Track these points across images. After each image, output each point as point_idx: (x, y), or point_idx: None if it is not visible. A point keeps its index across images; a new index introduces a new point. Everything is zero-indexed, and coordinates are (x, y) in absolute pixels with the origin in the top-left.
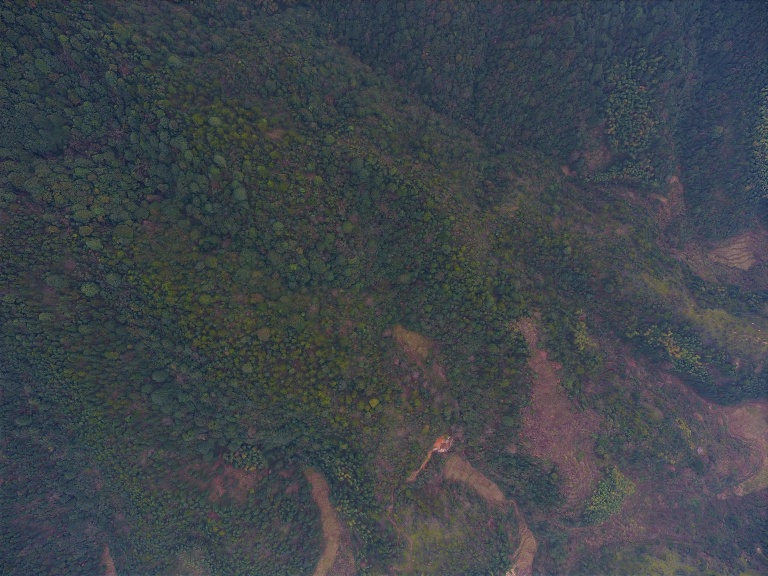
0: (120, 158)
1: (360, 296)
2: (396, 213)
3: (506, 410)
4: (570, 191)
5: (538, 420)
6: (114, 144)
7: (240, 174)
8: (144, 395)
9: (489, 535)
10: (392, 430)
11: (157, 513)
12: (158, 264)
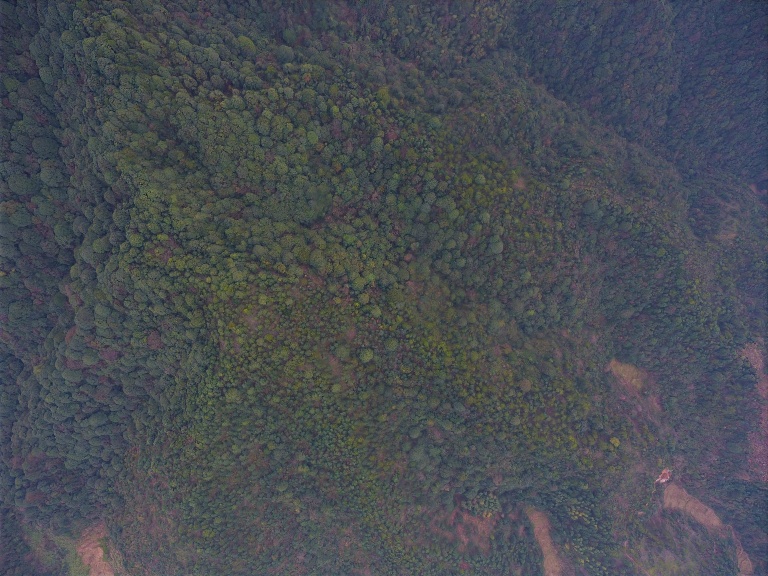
0: (373, 220)
1: (585, 334)
2: (624, 250)
3: (729, 436)
4: (763, 210)
5: (767, 445)
6: (368, 207)
7: (502, 229)
8: (404, 453)
9: (717, 562)
10: (631, 467)
11: (414, 568)
12: (431, 325)
